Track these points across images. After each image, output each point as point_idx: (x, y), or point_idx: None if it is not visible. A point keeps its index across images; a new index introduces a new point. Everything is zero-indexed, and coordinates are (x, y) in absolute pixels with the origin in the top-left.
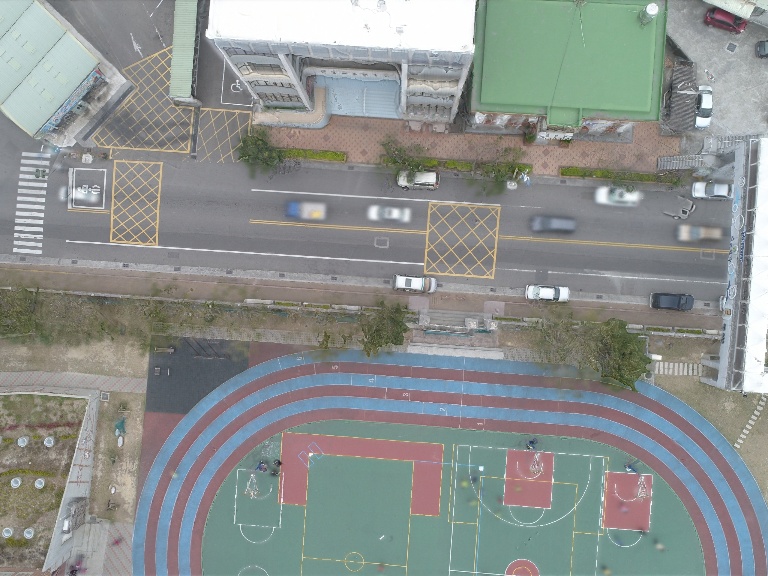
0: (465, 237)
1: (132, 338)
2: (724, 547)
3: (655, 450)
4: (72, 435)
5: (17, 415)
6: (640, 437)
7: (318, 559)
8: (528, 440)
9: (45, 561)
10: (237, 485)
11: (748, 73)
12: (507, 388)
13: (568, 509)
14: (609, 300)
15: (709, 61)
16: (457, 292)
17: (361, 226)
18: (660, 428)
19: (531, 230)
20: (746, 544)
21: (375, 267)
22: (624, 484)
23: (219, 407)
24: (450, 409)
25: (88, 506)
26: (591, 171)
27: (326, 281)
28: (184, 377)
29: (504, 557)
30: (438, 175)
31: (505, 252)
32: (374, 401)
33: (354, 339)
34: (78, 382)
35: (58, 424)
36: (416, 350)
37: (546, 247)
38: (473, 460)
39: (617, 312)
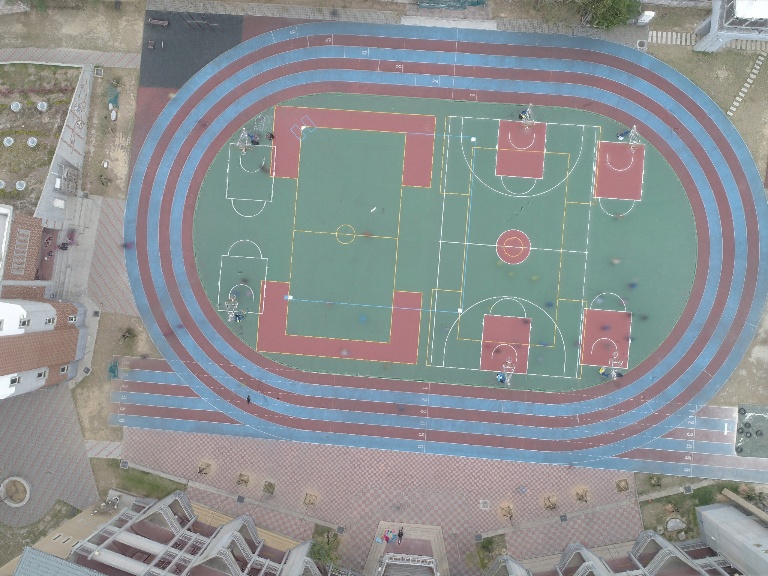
0: None
1: (126, 14)
2: (716, 216)
3: (648, 119)
4: (65, 100)
5: (11, 83)
6: (633, 106)
7: (309, 232)
8: (520, 110)
9: (36, 208)
10: (229, 159)
11: None
12: (500, 58)
13: (560, 179)
14: None
15: None
16: None
17: None
18: (653, 97)
19: None
20: (738, 212)
21: None
22: (616, 153)
23: (212, 81)
24: (443, 80)
25: (80, 181)
26: None
27: None
28: (178, 51)
29: (495, 228)
30: None
31: None
32: (367, 73)
33: (348, 12)
34: (72, 58)
35: (51, 90)
36: (409, 22)
37: None
38: (465, 131)
39: None
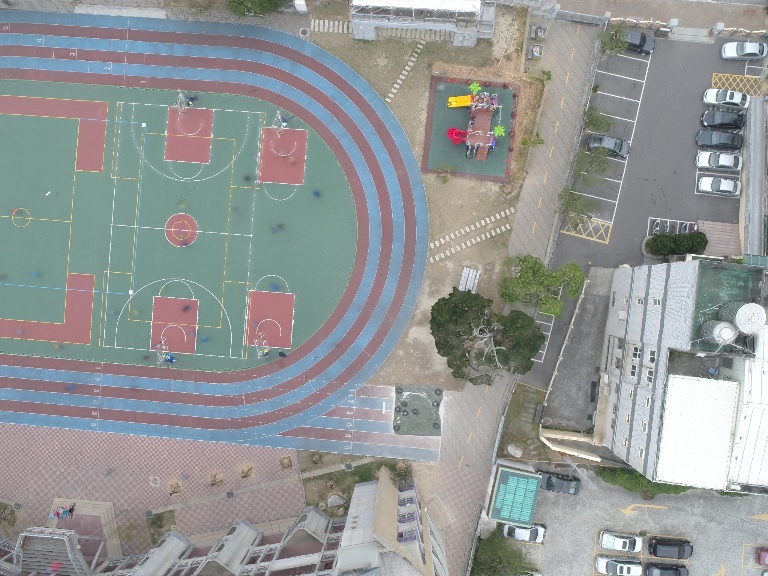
0: None
1: None
2: (375, 200)
3: (310, 105)
4: None
5: None
6: (296, 93)
7: None
8: (189, 97)
9: None
10: None
11: None
12: (169, 46)
13: (226, 164)
14: None
15: None
16: None
17: None
18: (315, 84)
19: None
20: (396, 196)
21: None
22: (280, 139)
23: None
24: (114, 67)
25: None
26: None
27: None
28: None
29: (164, 211)
30: None
31: None
32: (42, 61)
33: (24, 0)
34: None
35: None
36: (83, 10)
37: None
38: (136, 117)
39: None
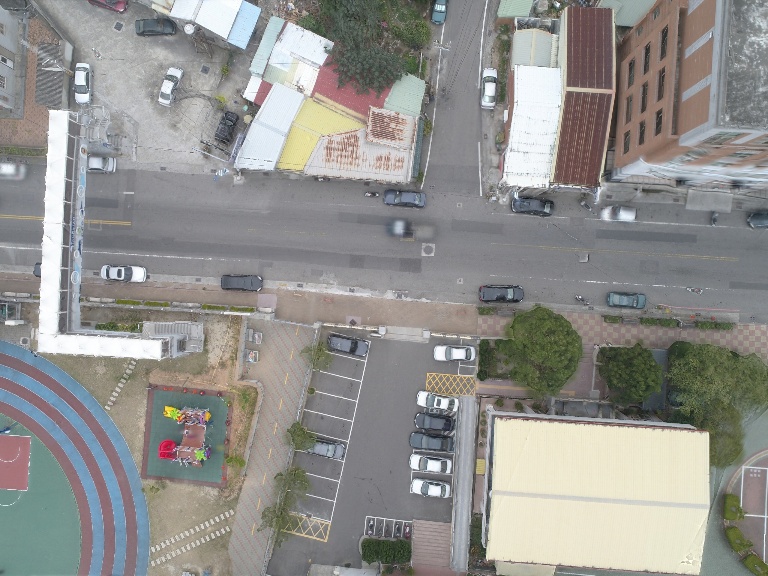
0: None
1: None
2: (97, 505)
3: (32, 413)
4: None
5: None
6: (18, 400)
7: None
8: None
9: None
10: None
11: (134, 51)
12: None
13: None
14: (5, 270)
15: (97, 40)
16: None
17: None
18: (36, 392)
19: None
20: (117, 502)
21: None
22: (4, 446)
23: None
24: None
25: None
26: None
27: None
28: None
29: None
30: None
31: None
32: None
33: None
34: None
35: None
36: None
37: None
38: None
39: (10, 281)
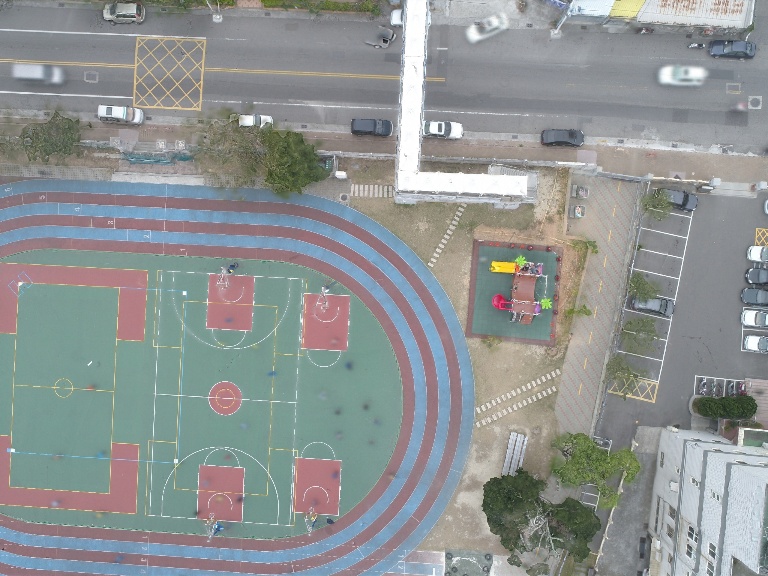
0: (172, 70)
1: None
2: (420, 365)
3: (352, 271)
4: None
5: None
6: (337, 259)
7: (29, 386)
8: (229, 264)
9: None
10: None
11: None
12: (208, 213)
13: (269, 331)
14: (314, 129)
15: None
16: (166, 124)
17: (71, 61)
18: (356, 249)
19: (236, 62)
20: (441, 361)
21: (86, 102)
22: None
23: None
24: (153, 236)
25: None
26: (291, 1)
27: (39, 117)
28: None
29: (207, 380)
30: (140, 7)
31: (211, 84)
32: (80, 230)
33: (60, 169)
34: None
35: None
36: (120, 178)
37: (251, 78)
38: (176, 285)
39: (321, 141)
